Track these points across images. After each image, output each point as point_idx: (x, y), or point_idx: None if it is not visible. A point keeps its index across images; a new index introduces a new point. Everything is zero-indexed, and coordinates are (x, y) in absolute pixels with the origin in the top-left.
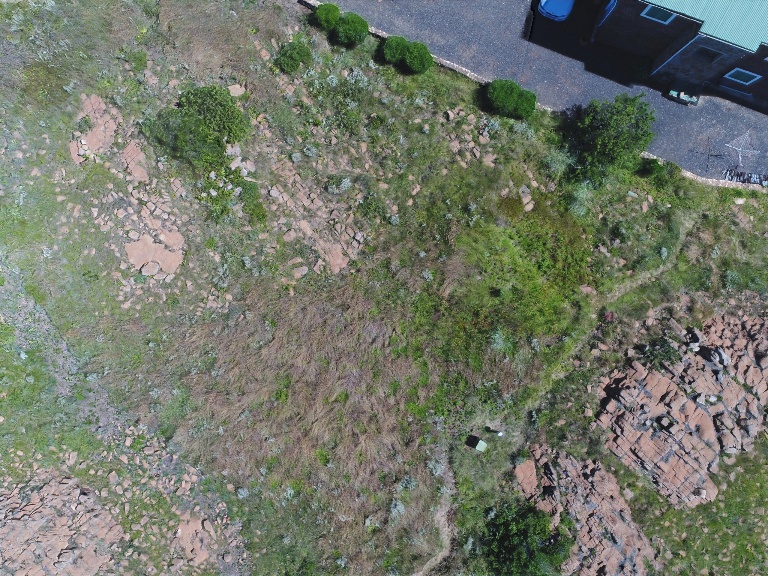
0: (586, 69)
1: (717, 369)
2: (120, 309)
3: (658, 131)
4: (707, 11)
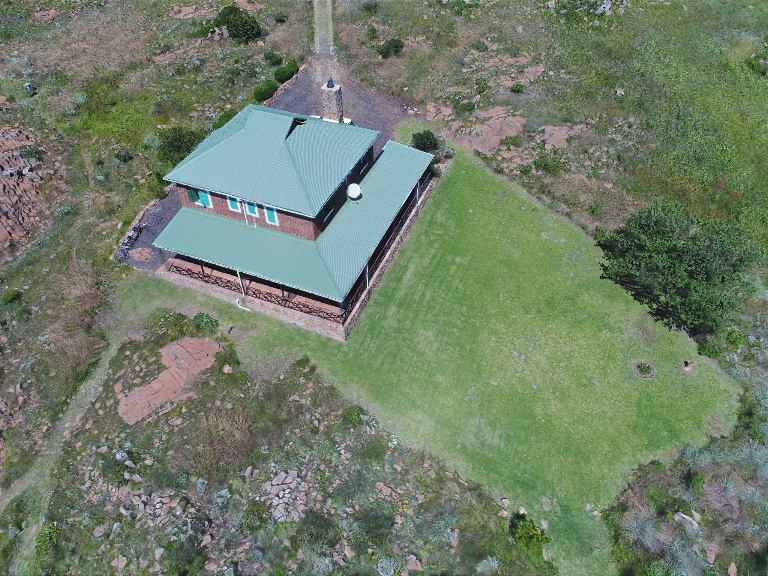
0: None
1: (3, 171)
2: (163, 4)
3: None
4: None
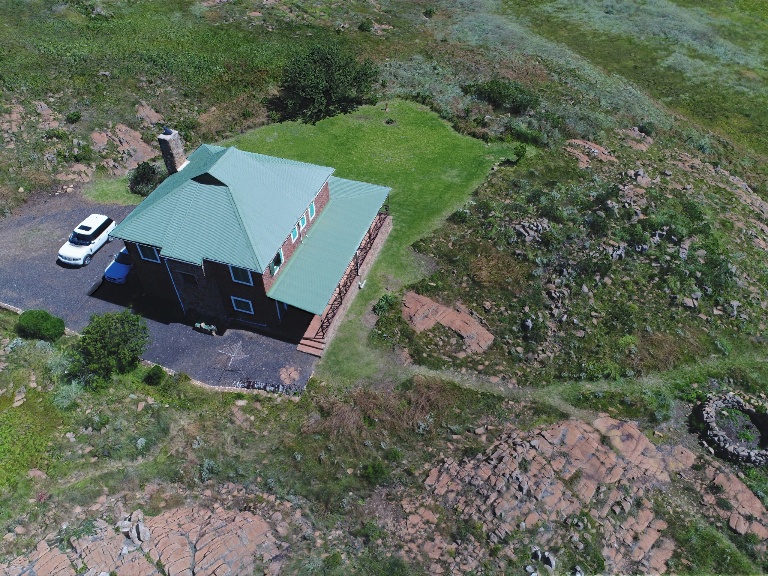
0: (132, 313)
1: None
2: None
3: (182, 353)
4: (163, 241)
